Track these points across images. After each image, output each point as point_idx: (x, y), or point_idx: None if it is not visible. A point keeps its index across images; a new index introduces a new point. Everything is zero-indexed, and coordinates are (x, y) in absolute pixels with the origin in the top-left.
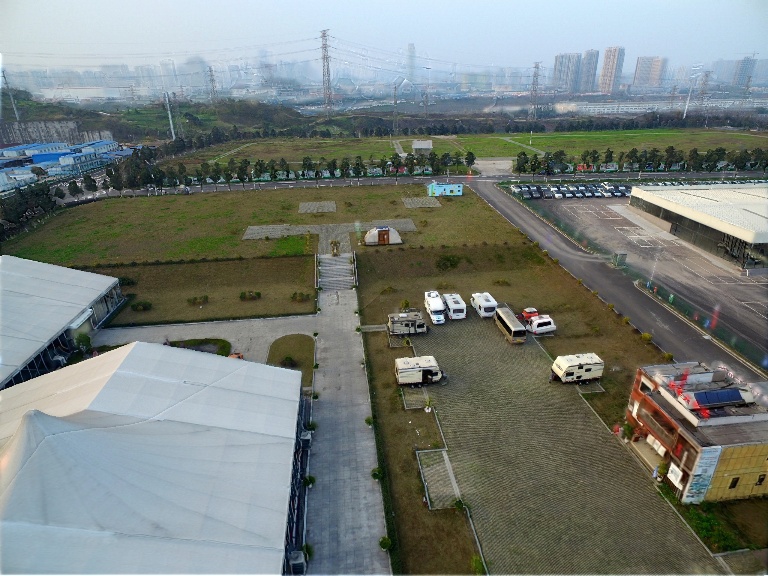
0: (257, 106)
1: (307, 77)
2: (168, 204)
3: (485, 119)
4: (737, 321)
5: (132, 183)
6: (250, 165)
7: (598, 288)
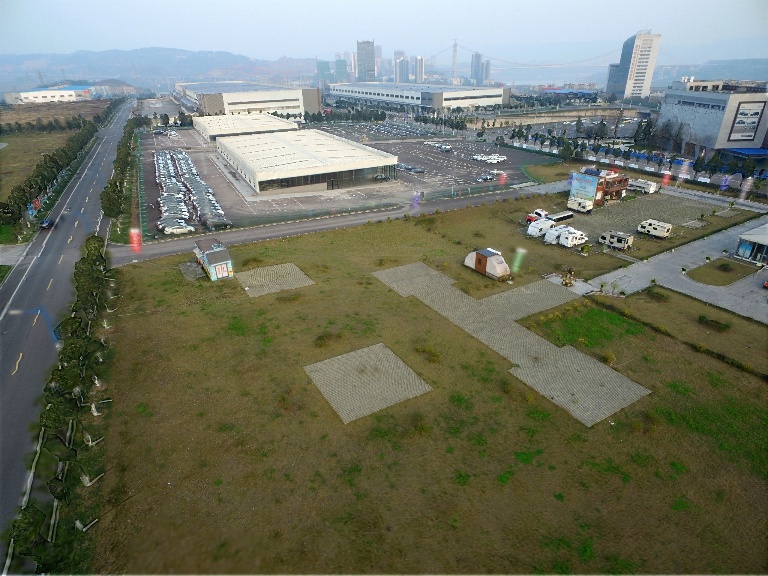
0: None
1: None
2: None
3: None
4: None
5: None
6: None
7: None
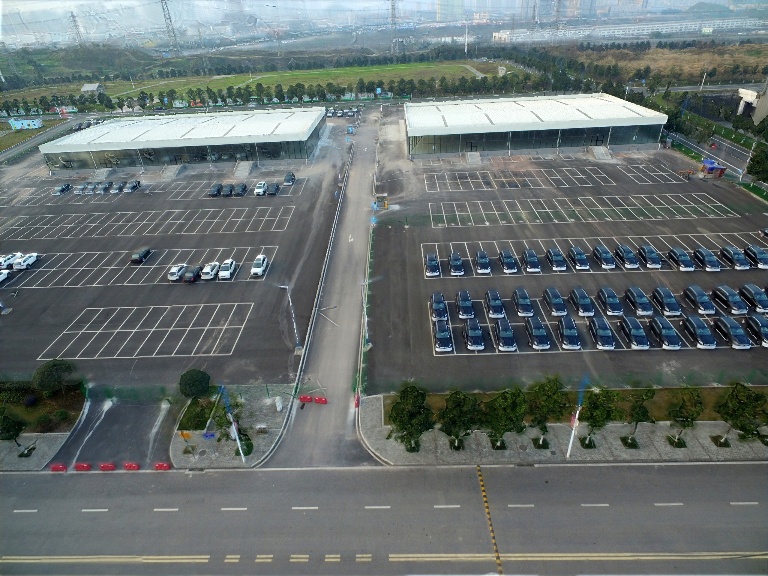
0: (106, 50)
1: (150, 20)
2: None
3: (333, 55)
4: None
5: None
6: None
7: None
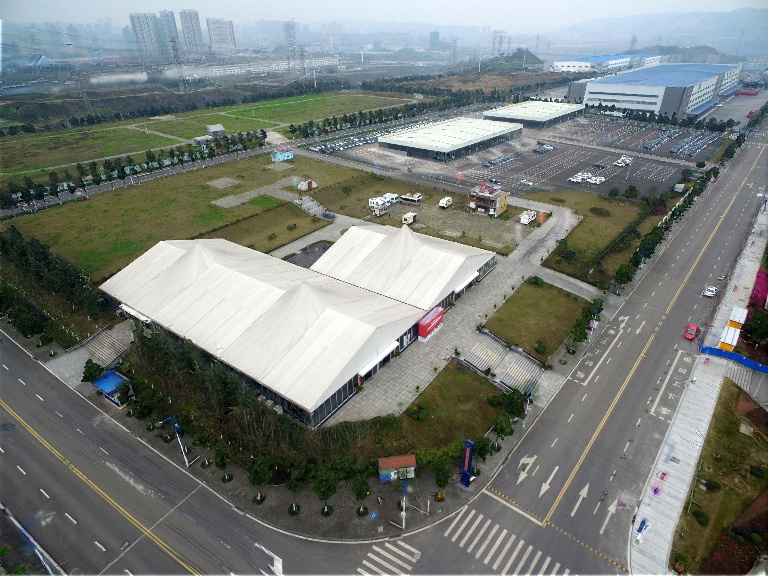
0: None
1: None
2: (95, 208)
3: (150, 94)
4: (461, 180)
5: (10, 203)
6: (60, 169)
7: (416, 182)
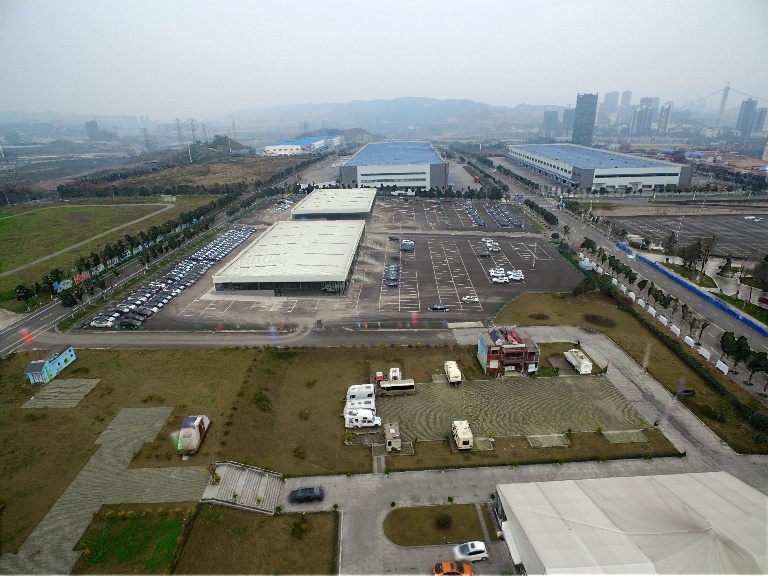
0: None
1: None
2: None
3: None
4: (399, 318)
5: None
6: None
7: (352, 343)
